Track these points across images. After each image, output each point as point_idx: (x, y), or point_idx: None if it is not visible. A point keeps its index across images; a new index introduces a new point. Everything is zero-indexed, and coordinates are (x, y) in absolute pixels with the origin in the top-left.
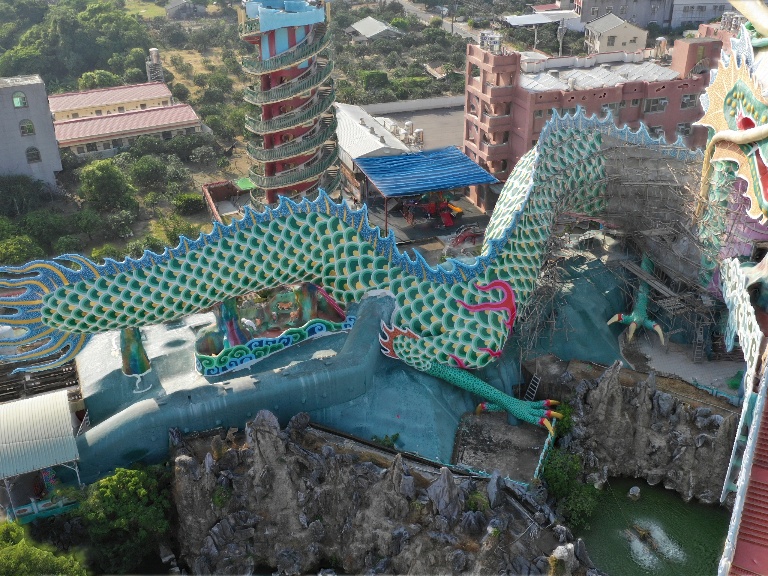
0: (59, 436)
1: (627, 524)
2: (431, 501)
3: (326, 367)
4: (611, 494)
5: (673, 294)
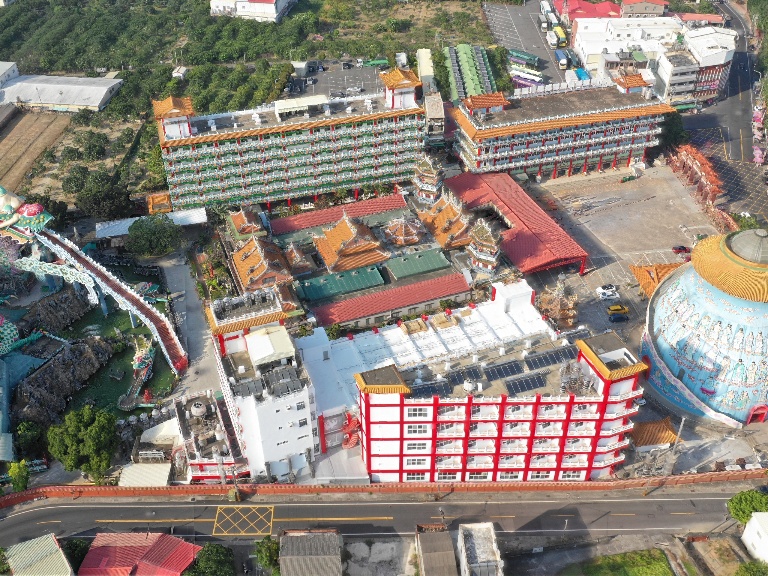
0: (1, 436)
1: (83, 333)
2: (68, 359)
3: (2, 370)
4: (72, 332)
5: (3, 284)
